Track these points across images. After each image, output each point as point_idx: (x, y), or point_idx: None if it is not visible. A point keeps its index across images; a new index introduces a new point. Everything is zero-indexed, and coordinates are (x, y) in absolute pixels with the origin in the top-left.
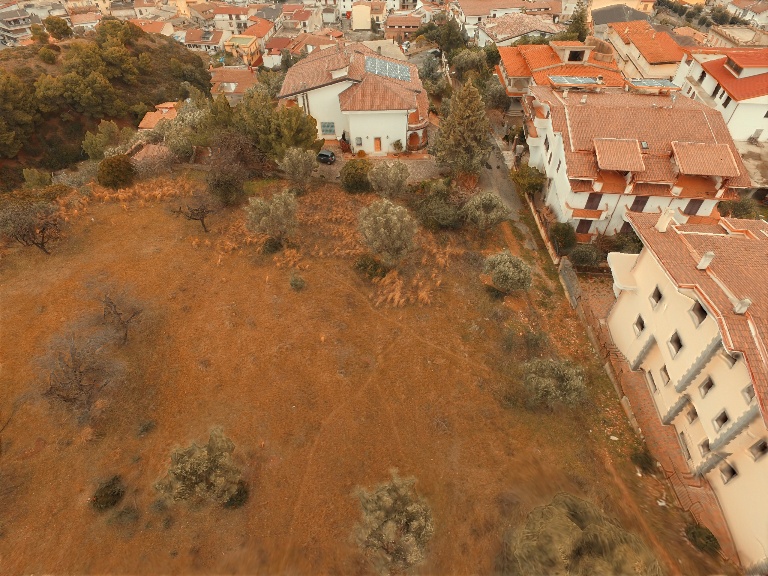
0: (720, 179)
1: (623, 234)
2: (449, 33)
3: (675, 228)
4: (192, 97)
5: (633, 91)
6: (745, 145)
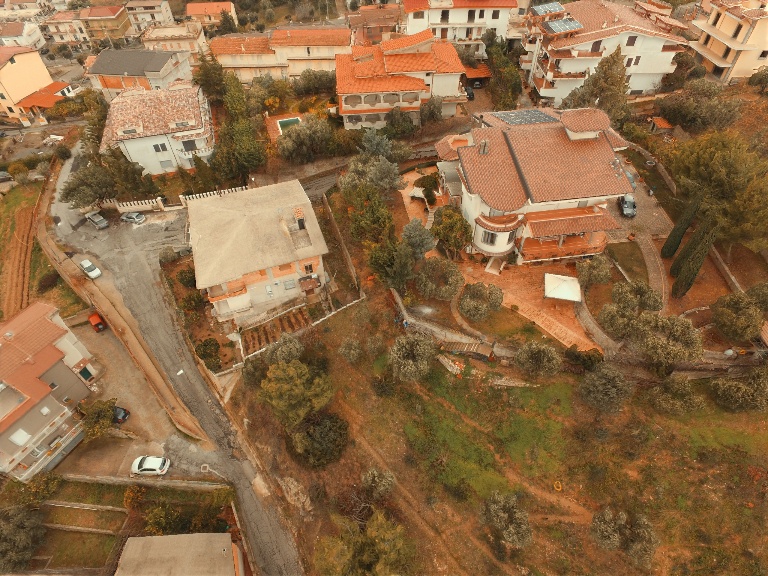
0: None
1: (676, 59)
2: (132, 166)
3: (762, 8)
4: (338, 573)
5: (556, 17)
6: (510, 32)
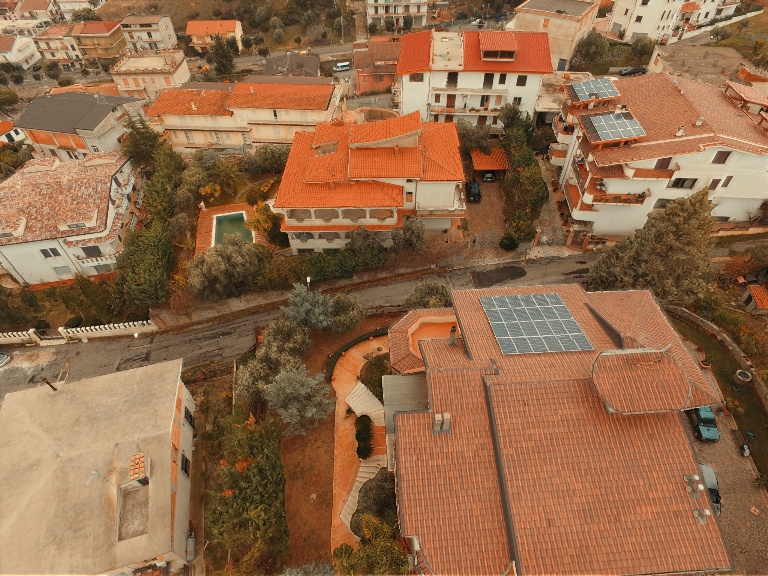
0: (738, 102)
1: None
2: None
3: None
4: None
5: (604, 103)
6: (541, 101)
